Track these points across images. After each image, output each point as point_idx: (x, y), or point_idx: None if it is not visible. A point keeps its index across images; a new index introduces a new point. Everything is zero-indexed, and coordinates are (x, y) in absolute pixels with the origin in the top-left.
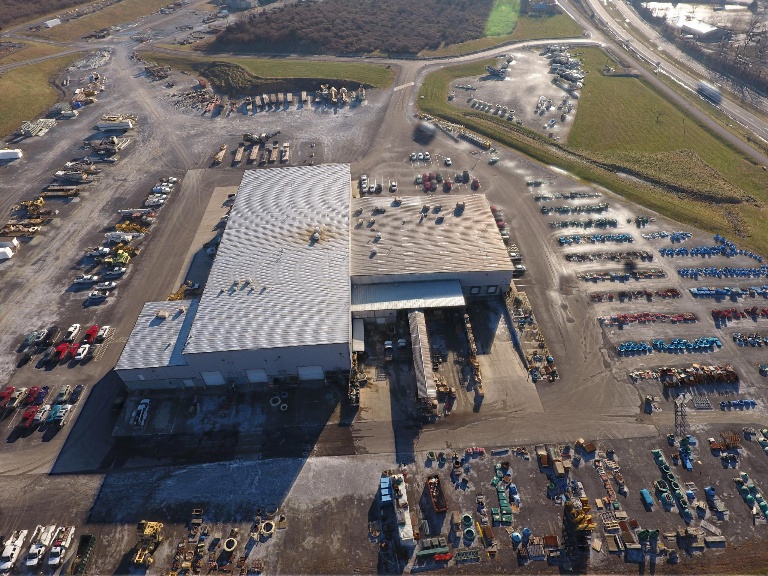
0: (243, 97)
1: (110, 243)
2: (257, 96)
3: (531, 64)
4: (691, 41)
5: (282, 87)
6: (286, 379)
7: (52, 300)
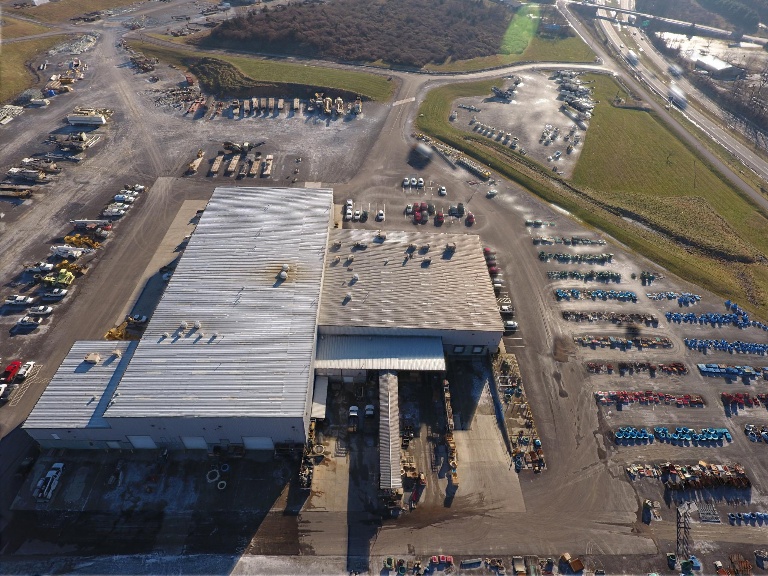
0: (231, 99)
1: (56, 257)
2: (246, 99)
3: (539, 88)
4: (705, 77)
5: (274, 92)
6: (229, 449)
7: None
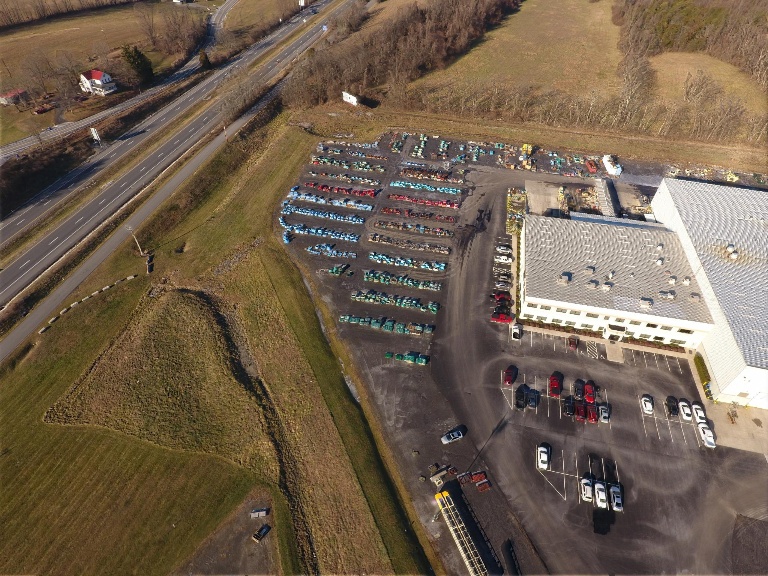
0: None
1: None
2: None
3: None
4: None
5: None
6: None
7: None
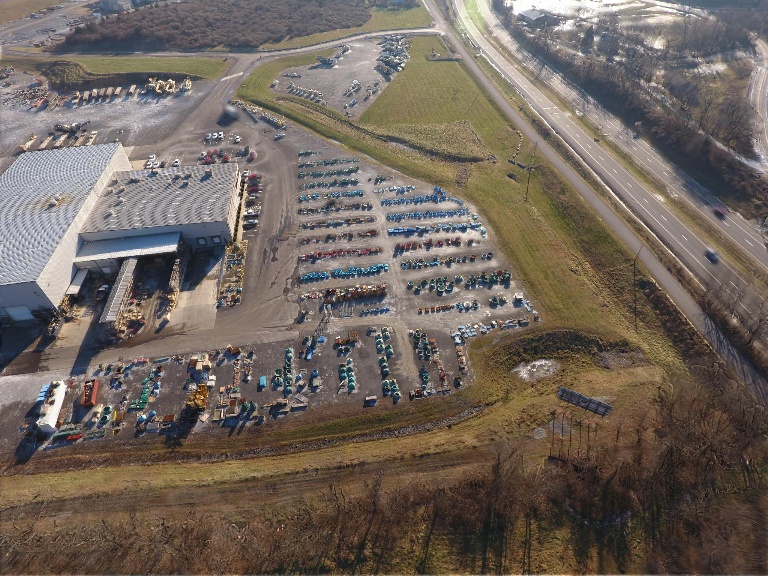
0: None
1: None
2: (87, 91)
3: (365, 53)
4: (519, 27)
5: (114, 82)
6: None
7: None
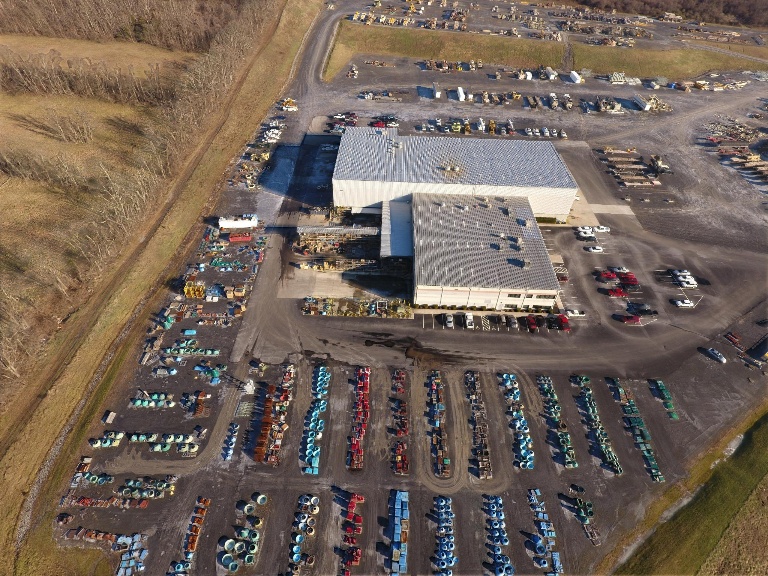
0: (765, 156)
1: None
2: None
3: None
4: None
5: None
6: None
7: (422, 117)
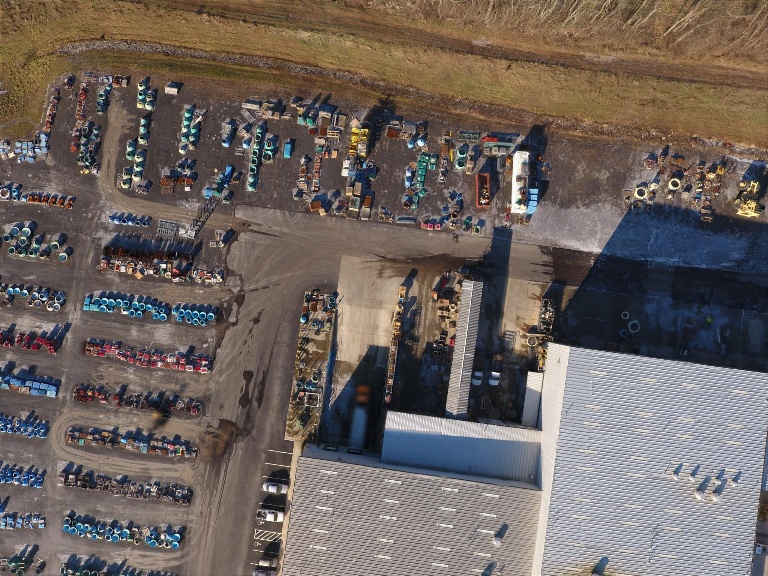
0: None
1: None
2: None
3: None
4: None
5: None
6: None
7: None
